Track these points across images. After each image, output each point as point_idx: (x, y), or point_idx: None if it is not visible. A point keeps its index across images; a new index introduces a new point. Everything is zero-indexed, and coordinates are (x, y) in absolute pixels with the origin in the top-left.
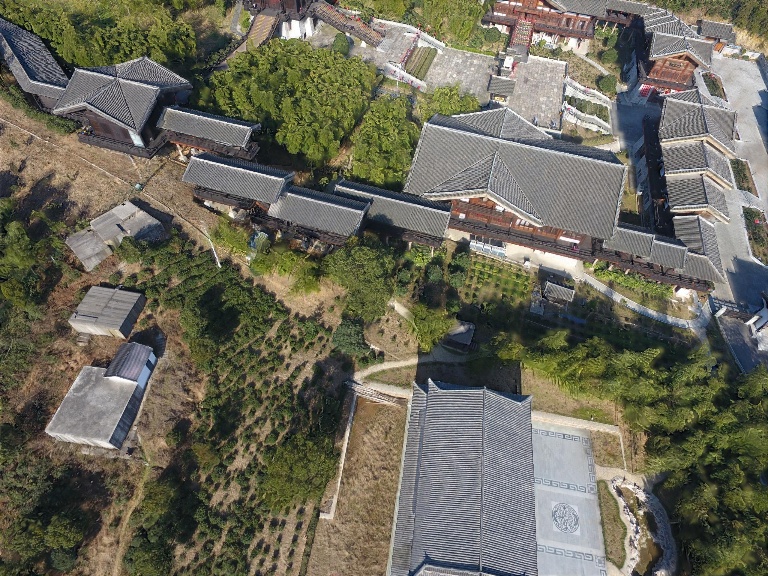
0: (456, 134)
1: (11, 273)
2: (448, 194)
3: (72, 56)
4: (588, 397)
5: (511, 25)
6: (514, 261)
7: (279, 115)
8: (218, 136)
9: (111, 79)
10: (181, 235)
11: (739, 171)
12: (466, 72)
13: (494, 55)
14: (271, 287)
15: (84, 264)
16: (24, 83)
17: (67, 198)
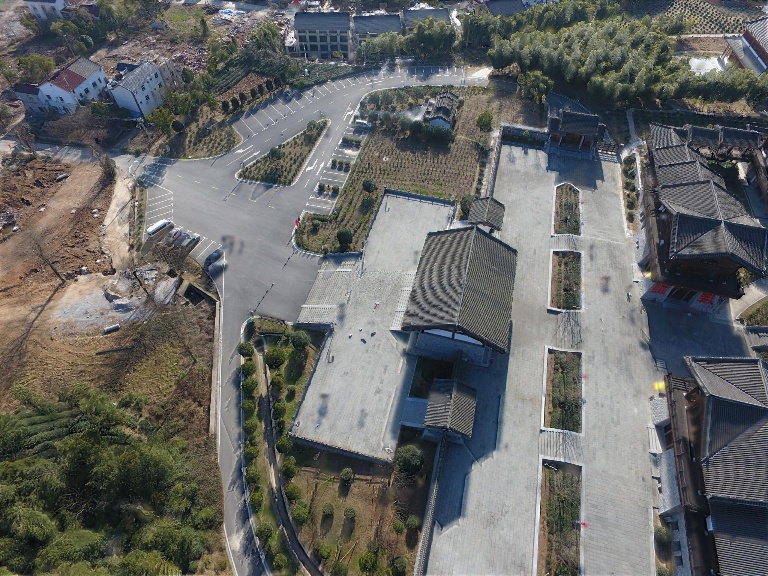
0: None
1: None
2: None
3: None
4: (707, 105)
5: None
6: None
7: None
8: None
9: None
10: None
11: (569, 284)
12: None
13: None
14: None
15: None
16: None
17: None
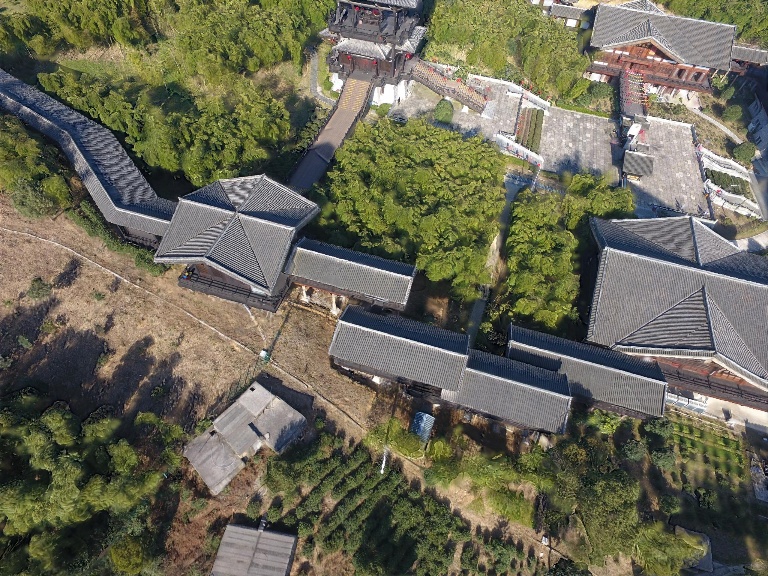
0: (647, 262)
1: (113, 506)
2: (653, 350)
3: (155, 158)
4: None
5: (615, 76)
6: (713, 416)
7: (417, 233)
8: (368, 288)
9: (228, 214)
10: (326, 426)
11: None
12: (582, 140)
13: (608, 116)
14: (442, 490)
15: (212, 491)
16: (107, 210)
17: (171, 372)
